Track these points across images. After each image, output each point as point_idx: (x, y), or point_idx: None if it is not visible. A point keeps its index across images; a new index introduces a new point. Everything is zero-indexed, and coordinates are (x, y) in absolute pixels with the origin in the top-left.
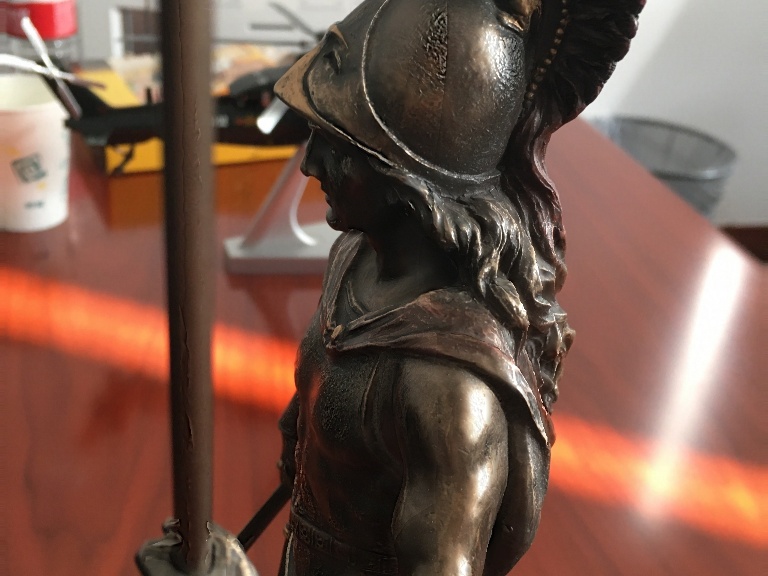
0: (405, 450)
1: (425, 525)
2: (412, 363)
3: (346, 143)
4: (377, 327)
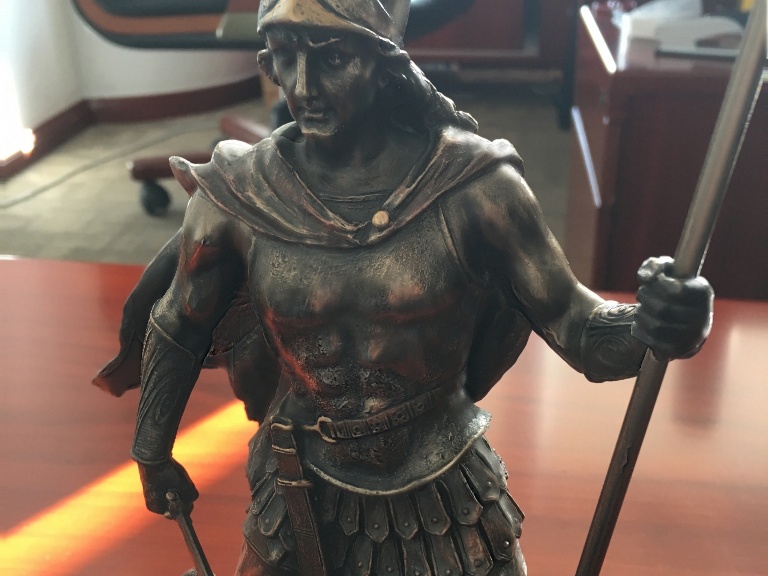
0: (515, 238)
1: (558, 270)
2: (481, 181)
3: (373, 39)
4: (429, 182)
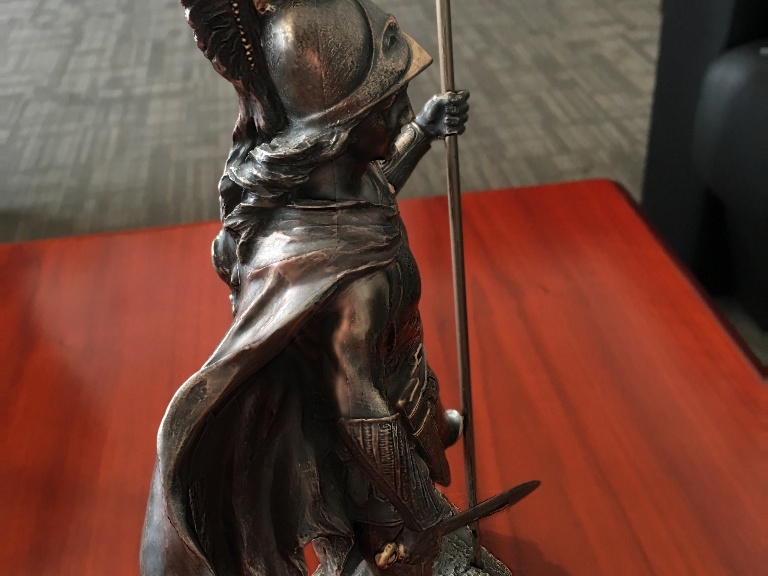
0: None
1: None
2: None
3: None
4: None
